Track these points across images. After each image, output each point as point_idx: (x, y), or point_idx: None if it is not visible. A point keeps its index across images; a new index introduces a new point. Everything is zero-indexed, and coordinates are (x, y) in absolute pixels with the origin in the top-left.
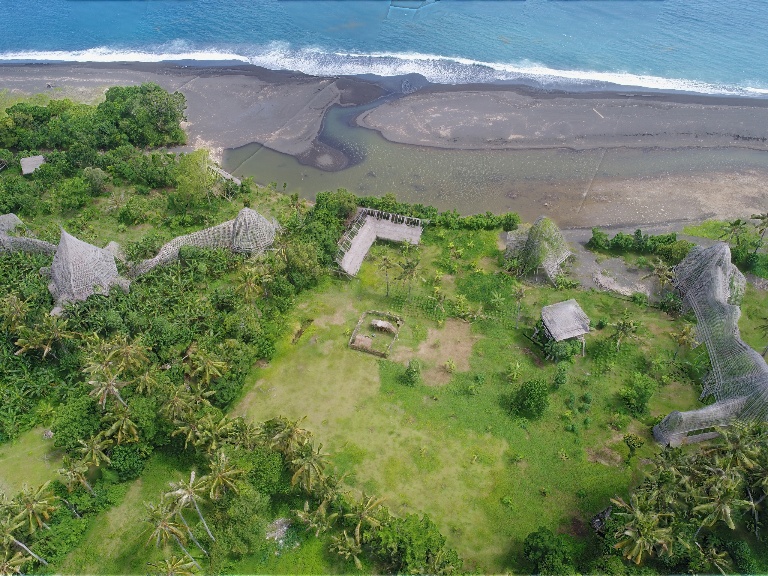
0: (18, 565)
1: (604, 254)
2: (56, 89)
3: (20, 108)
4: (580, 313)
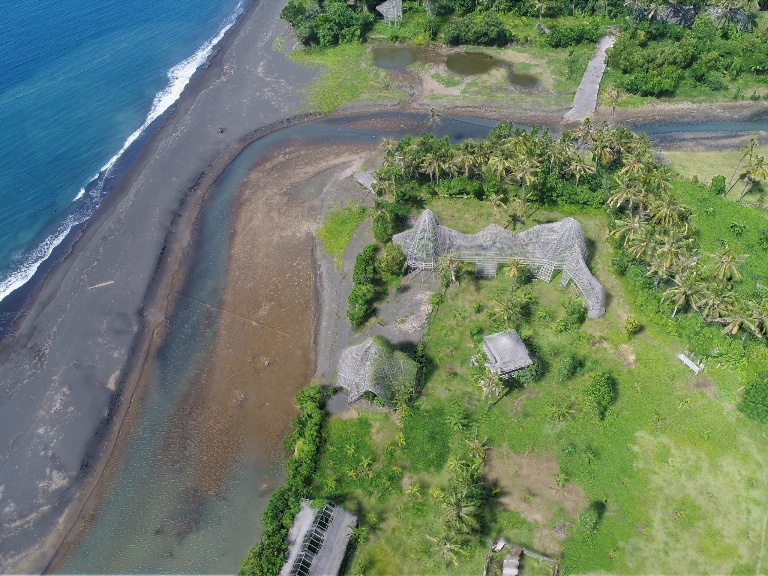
0: None
1: (370, 318)
2: None
3: None
4: (509, 333)
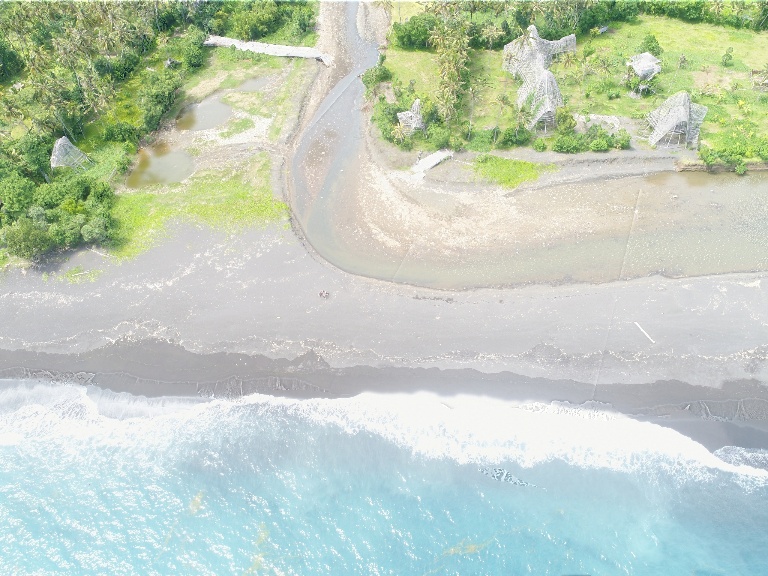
0: None
1: None
2: None
3: None
4: (638, 55)
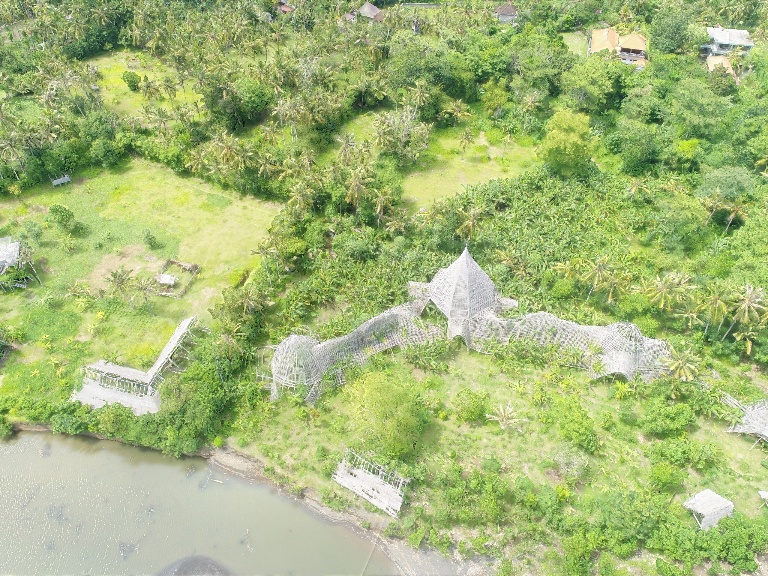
0: (375, 123)
1: None
2: None
3: None
4: None
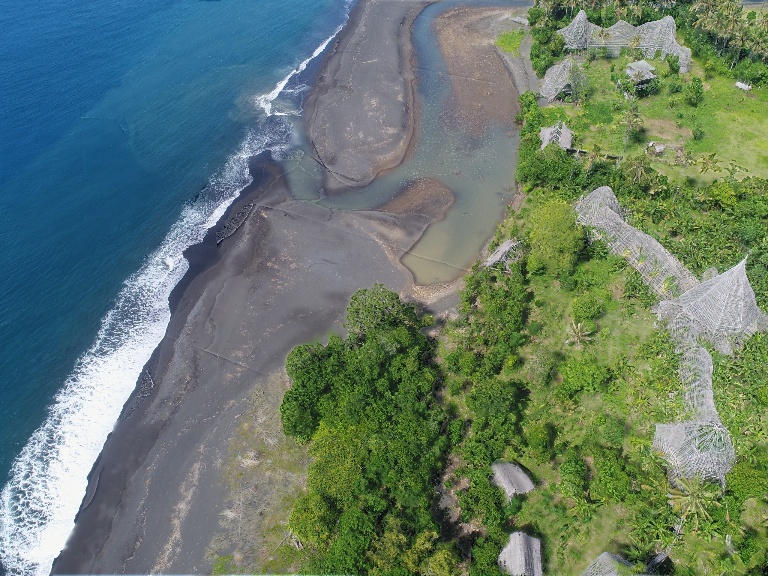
0: None
1: None
2: (222, 570)
3: (352, 565)
4: None
